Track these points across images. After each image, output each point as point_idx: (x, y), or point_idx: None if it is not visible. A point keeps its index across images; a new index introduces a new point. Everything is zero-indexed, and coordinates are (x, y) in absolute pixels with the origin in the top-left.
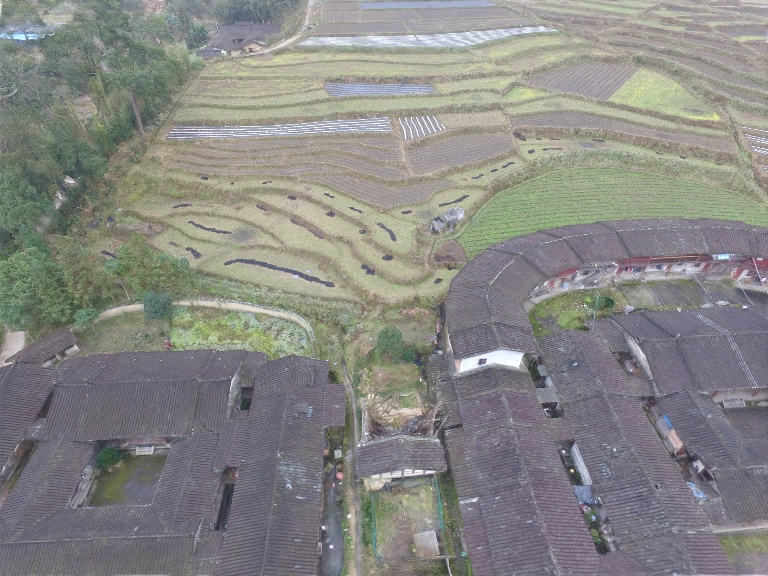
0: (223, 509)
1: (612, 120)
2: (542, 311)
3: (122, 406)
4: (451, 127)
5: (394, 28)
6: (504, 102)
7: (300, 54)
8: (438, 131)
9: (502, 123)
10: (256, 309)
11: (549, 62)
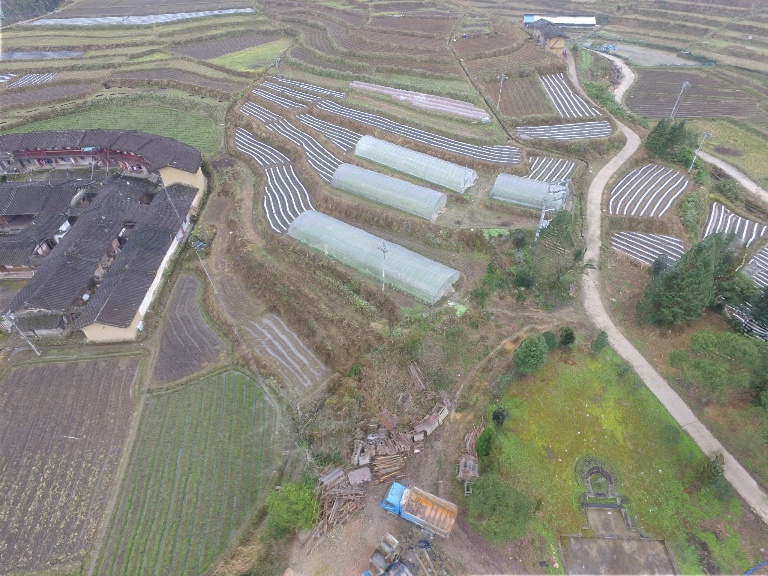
0: None
1: (188, 74)
2: None
3: None
4: (54, 79)
5: (121, 11)
6: (119, 62)
7: (18, 32)
8: (42, 82)
9: (98, 76)
10: None
11: (208, 35)
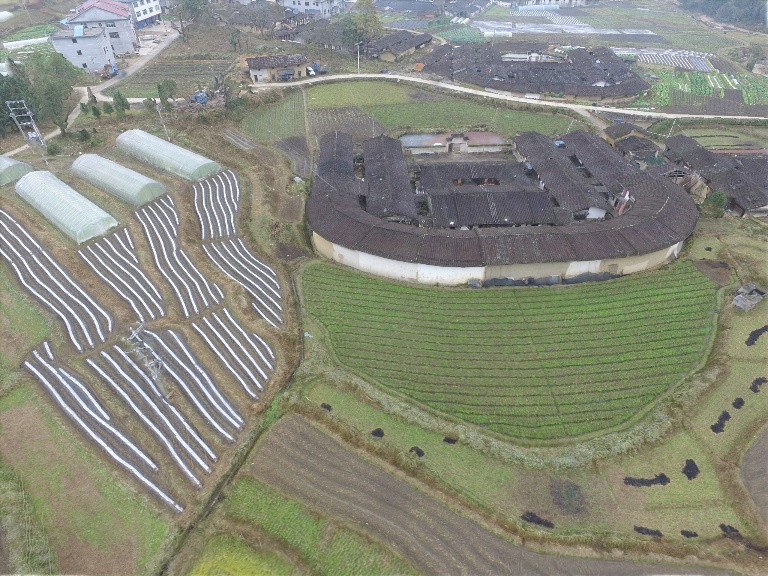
0: None
1: None
2: None
3: None
4: None
5: None
6: None
7: None
8: None
9: None
10: None
11: None
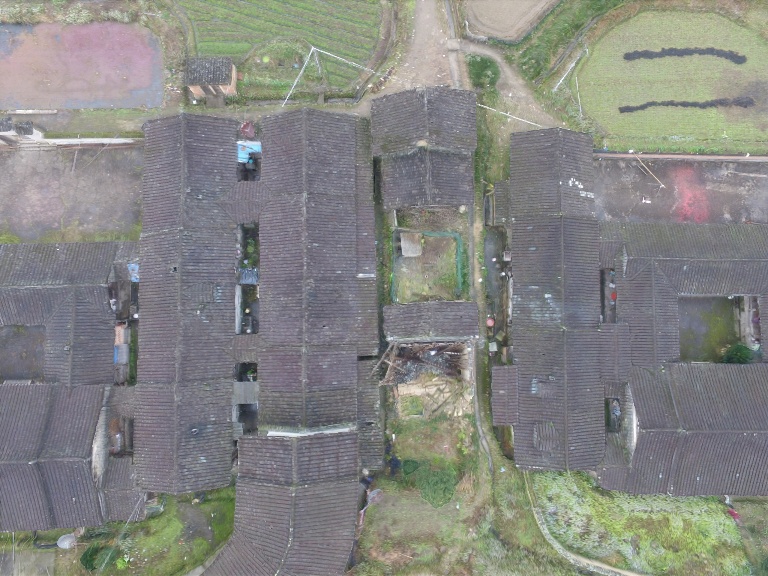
0: (601, 300)
1: None
2: (197, 552)
3: (759, 401)
4: None
5: None
6: None
7: None
8: None
9: None
10: (630, 575)
11: None
